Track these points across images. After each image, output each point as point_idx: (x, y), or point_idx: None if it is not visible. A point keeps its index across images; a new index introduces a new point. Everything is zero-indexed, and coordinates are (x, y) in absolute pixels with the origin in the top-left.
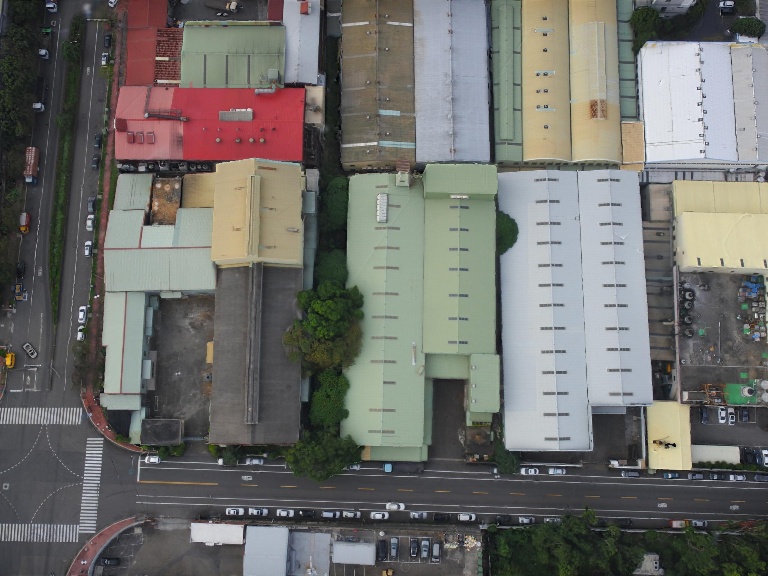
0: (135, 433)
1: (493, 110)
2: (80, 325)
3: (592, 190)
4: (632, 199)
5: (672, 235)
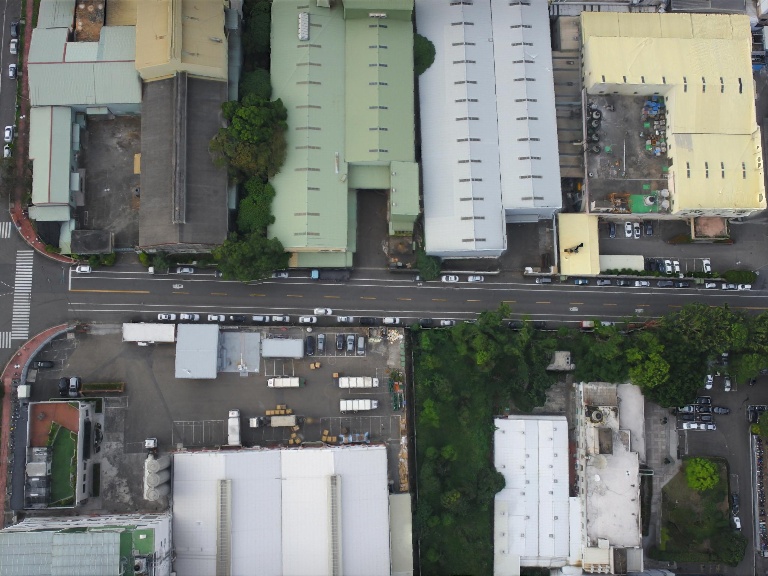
0: (65, 244)
1: None
2: (6, 144)
3: (504, 14)
4: (542, 22)
5: (581, 63)
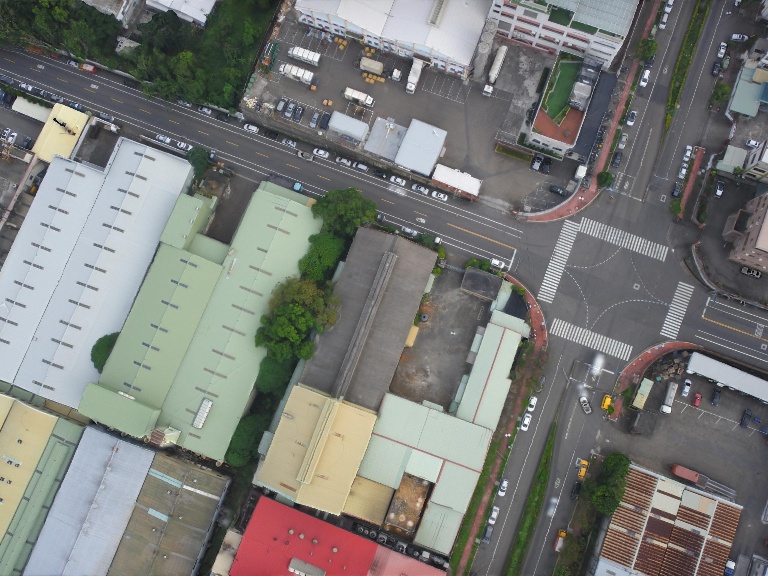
0: (506, 291)
1: (62, 481)
2: (531, 413)
3: (8, 360)
4: None
5: None
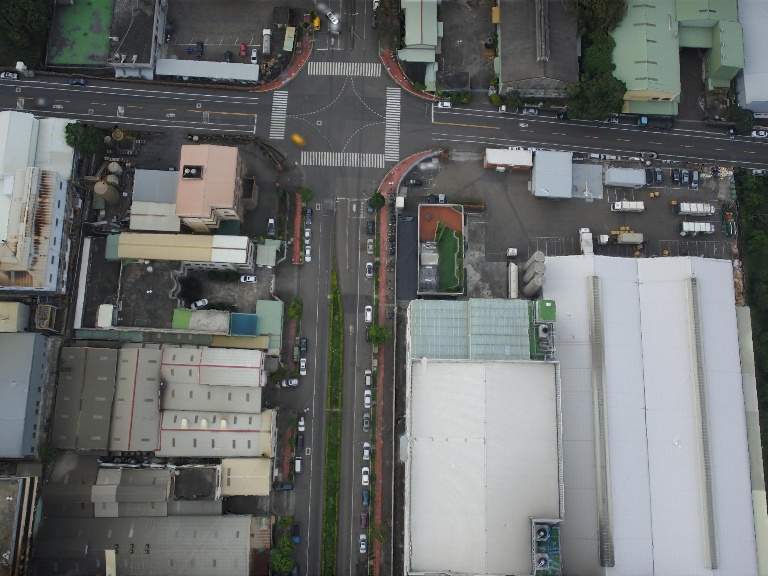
0: (430, 82)
1: None
2: None
3: None
4: None
5: None
